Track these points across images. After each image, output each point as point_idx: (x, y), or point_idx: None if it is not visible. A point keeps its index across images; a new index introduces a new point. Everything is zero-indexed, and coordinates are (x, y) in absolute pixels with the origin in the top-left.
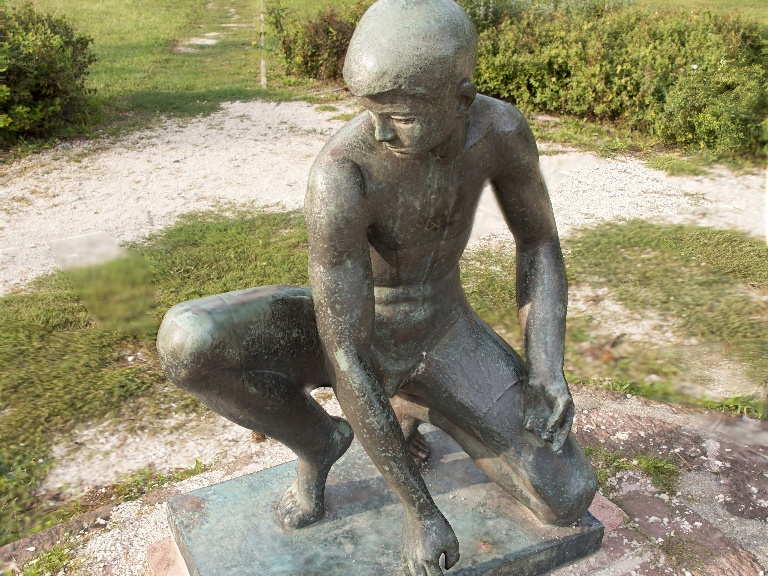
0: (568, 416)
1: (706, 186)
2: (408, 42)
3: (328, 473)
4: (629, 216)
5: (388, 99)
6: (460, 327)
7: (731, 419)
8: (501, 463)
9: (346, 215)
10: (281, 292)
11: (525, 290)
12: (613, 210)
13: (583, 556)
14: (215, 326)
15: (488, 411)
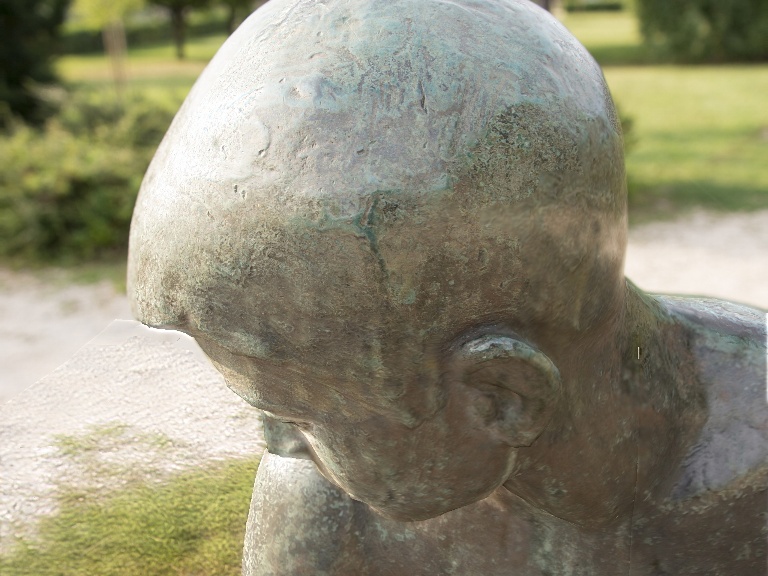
0: None
1: None
2: (217, 162)
3: None
4: None
5: (205, 346)
6: None
7: None
8: None
9: None
10: None
11: None
12: None
13: None
14: None
15: None
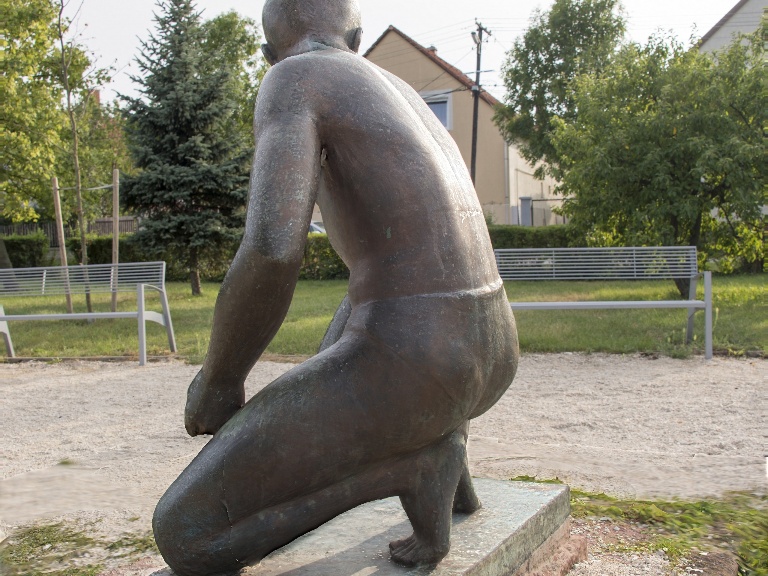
0: None
1: None
2: None
3: (475, 526)
4: None
5: None
6: None
7: None
8: None
9: None
10: None
11: None
12: None
13: None
14: None
15: None
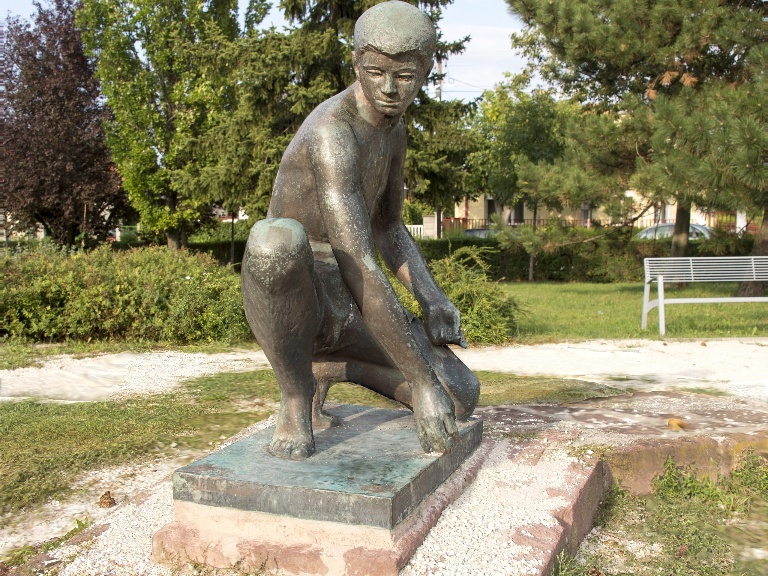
0: None
1: (244, 356)
2: (418, 22)
3: None
4: (214, 372)
5: (407, 58)
6: None
7: None
8: None
9: (356, 155)
10: None
11: (400, 254)
12: (195, 372)
13: None
14: None
15: None
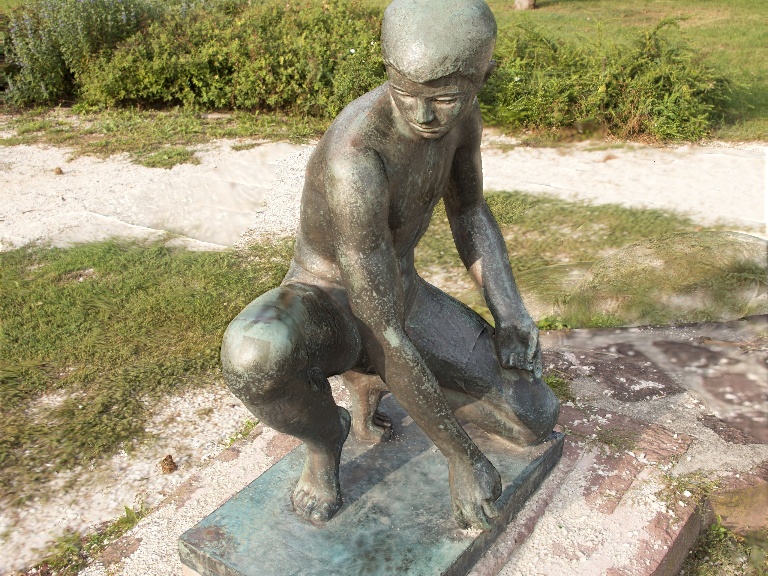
0: (537, 346)
1: None
2: (461, 28)
3: None
4: None
5: (443, 82)
6: (422, 294)
7: (568, 333)
8: (483, 405)
9: (380, 200)
10: (297, 291)
11: (473, 248)
12: None
13: (555, 465)
14: (290, 330)
15: (468, 361)
